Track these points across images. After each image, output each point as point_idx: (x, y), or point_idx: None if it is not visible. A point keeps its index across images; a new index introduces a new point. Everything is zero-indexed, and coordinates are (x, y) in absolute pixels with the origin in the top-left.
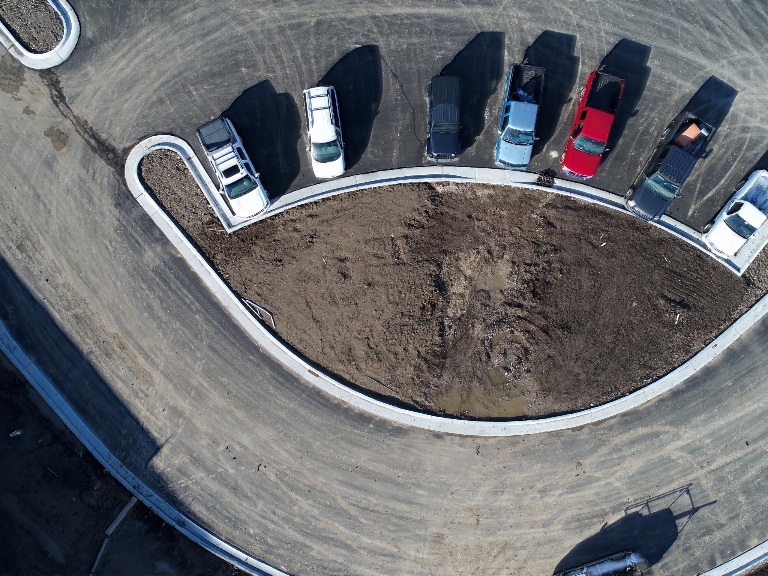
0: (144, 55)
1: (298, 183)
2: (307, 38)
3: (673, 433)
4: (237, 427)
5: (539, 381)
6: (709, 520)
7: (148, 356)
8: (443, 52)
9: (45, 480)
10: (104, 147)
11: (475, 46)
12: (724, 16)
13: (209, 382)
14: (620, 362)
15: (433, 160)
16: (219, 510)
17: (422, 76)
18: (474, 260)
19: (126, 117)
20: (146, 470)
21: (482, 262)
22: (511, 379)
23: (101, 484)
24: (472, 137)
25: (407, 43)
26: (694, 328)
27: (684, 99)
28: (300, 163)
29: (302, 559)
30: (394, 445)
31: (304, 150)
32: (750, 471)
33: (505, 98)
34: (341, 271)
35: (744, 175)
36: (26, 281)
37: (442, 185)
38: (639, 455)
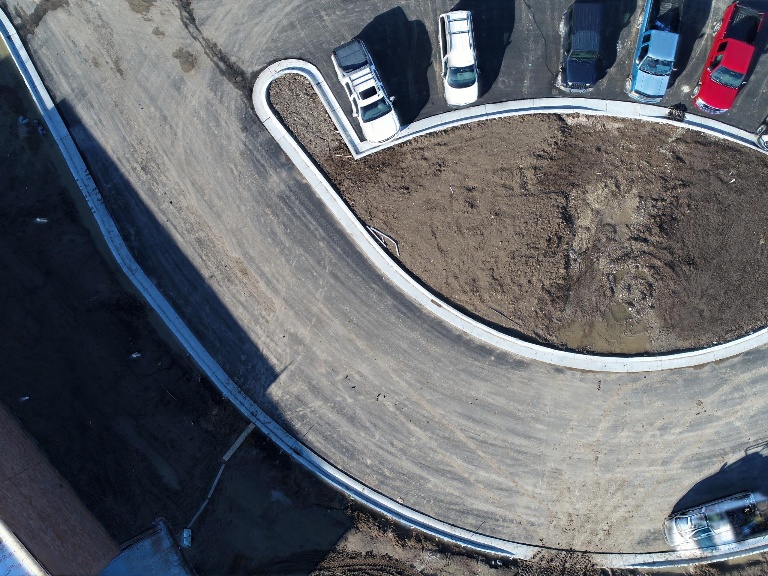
0: None
1: (427, 111)
2: None
3: None
4: (357, 356)
5: (663, 317)
6: None
7: (270, 282)
8: None
9: (164, 403)
10: (232, 70)
11: None
12: None
13: (331, 309)
14: (745, 300)
15: (566, 90)
16: (337, 439)
17: (555, 7)
18: (601, 193)
19: (255, 40)
20: (264, 397)
21: (609, 196)
22: (634, 315)
23: (220, 409)
24: (603, 69)
25: None
26: None
27: None
28: (429, 91)
29: (419, 491)
30: (515, 378)
31: (434, 78)
32: None
33: (642, 28)
34: (468, 200)
35: None
36: (150, 202)
37: (572, 117)
38: (761, 395)
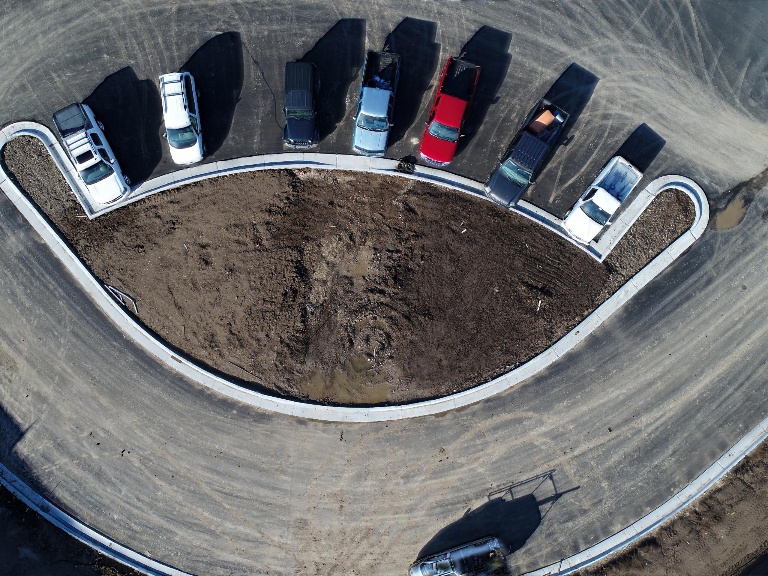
0: (6, 42)
1: (160, 169)
2: (168, 25)
3: (536, 419)
4: (101, 413)
5: (402, 367)
6: (572, 506)
7: (12, 342)
8: (304, 39)
9: None
10: None
11: (336, 33)
12: (585, 3)
13: (73, 368)
14: (482, 348)
15: (291, 146)
16: (83, 495)
17: (283, 63)
18: (336, 246)
19: None
20: (10, 456)
21: (344, 248)
22: (374, 365)
23: None
24: (333, 124)
25: (268, 30)
26: (556, 314)
27: (545, 86)
28: (162, 150)
29: (166, 544)
30: (258, 431)
31: None
32: (613, 457)
33: (361, 84)
34: (203, 257)
35: (605, 162)
36: None
37: (303, 172)
38: (502, 441)
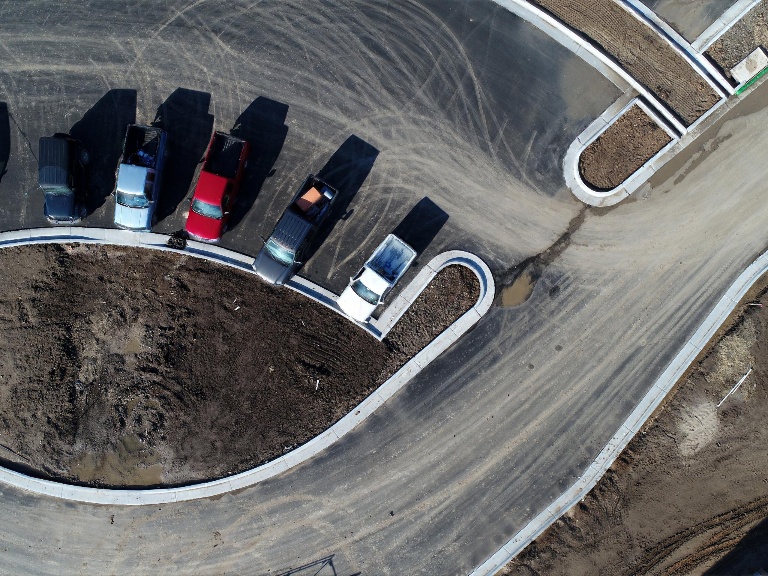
0: None
1: None
2: None
3: (315, 502)
4: None
5: (175, 448)
6: None
7: None
8: (72, 110)
9: None
10: None
11: (105, 104)
12: (364, 74)
13: None
14: (258, 429)
15: (53, 222)
16: None
17: (51, 134)
18: (106, 323)
19: None
20: None
21: (115, 325)
22: (147, 446)
23: None
24: (102, 197)
25: (36, 100)
26: (336, 394)
27: (323, 159)
28: None
29: None
30: (25, 514)
31: None
32: (395, 542)
33: None
34: None
35: None
36: None
37: (71, 246)
38: (280, 525)
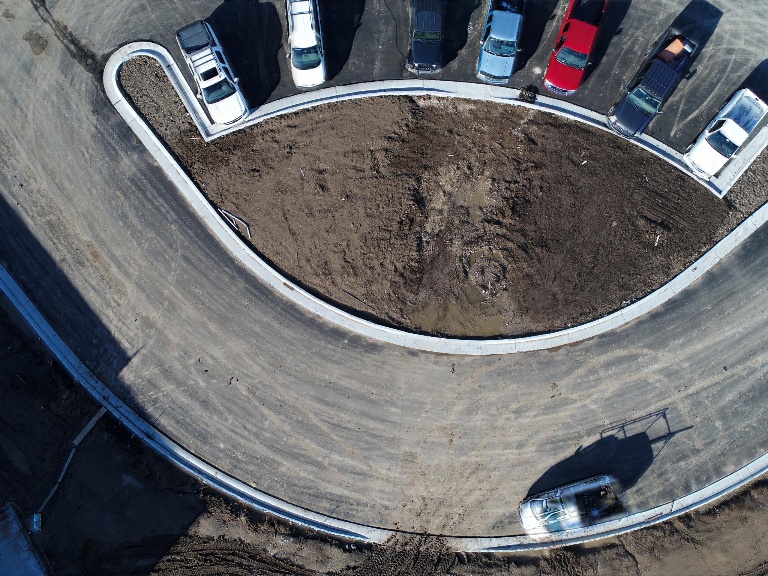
0: None
1: (278, 93)
2: None
3: (651, 356)
4: (210, 339)
5: (516, 300)
6: (685, 445)
7: (122, 265)
8: None
9: (14, 387)
10: (83, 52)
11: None
12: None
13: (183, 293)
14: (599, 283)
15: (414, 71)
16: (189, 423)
17: None
18: (454, 176)
19: (106, 23)
20: (117, 380)
21: (462, 178)
22: (488, 297)
23: (70, 393)
24: (454, 51)
25: None
26: (674, 250)
27: (669, 19)
28: (280, 73)
29: (272, 475)
30: (368, 361)
31: (285, 60)
32: (728, 397)
33: (488, 9)
34: (319, 183)
35: (727, 97)
36: (0, 186)
37: (423, 99)
38: (616, 378)
